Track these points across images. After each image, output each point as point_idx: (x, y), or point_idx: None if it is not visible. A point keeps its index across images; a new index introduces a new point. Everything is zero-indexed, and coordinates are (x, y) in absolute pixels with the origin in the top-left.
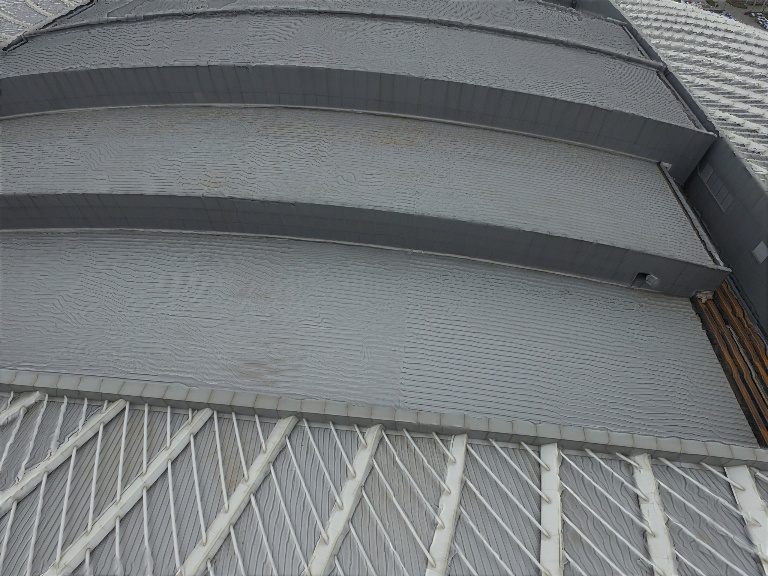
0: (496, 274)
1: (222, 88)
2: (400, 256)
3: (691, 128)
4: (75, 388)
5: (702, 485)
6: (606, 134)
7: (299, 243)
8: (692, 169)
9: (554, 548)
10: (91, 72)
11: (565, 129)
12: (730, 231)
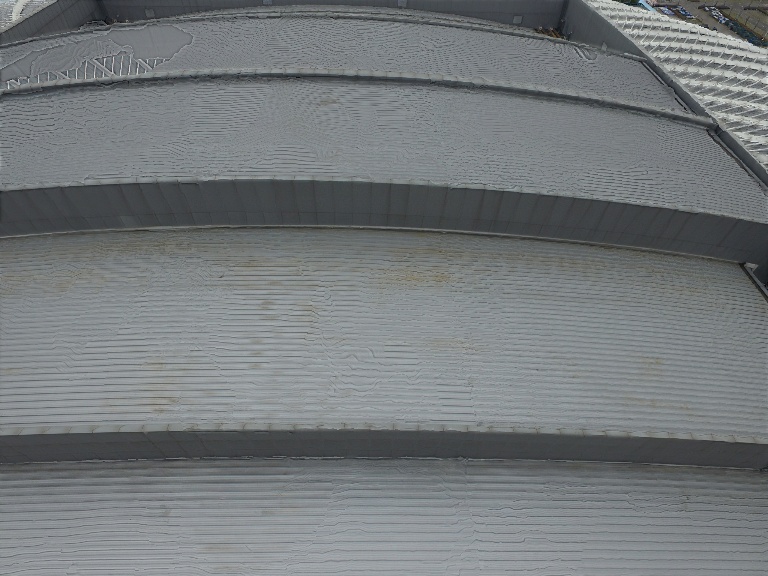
0: (587, 482)
1: (162, 209)
2: (448, 464)
3: None
4: None
5: None
6: (684, 238)
7: (300, 463)
8: None
9: None
10: None
11: (633, 235)
12: None
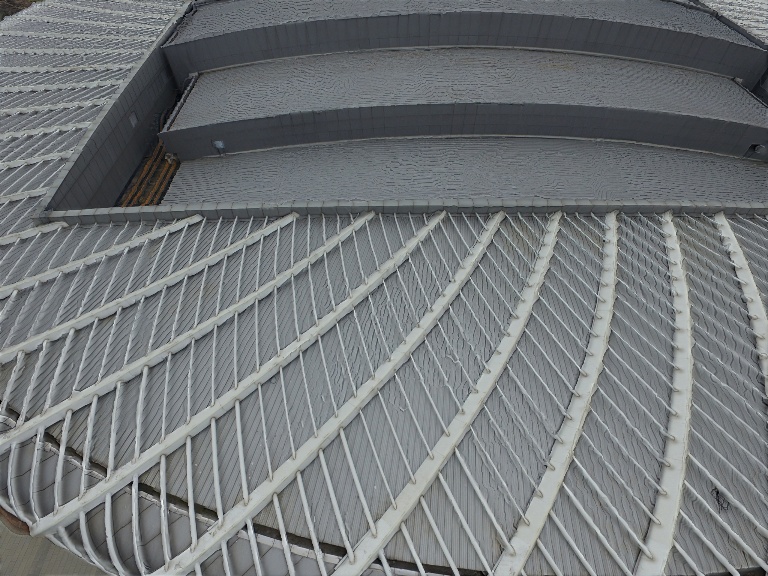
0: (656, 152)
1: (414, 33)
2: (585, 145)
3: (760, 49)
4: (472, 205)
5: None
6: (700, 57)
7: (514, 139)
8: (756, 82)
9: None
10: (308, 24)
11: (671, 54)
12: None
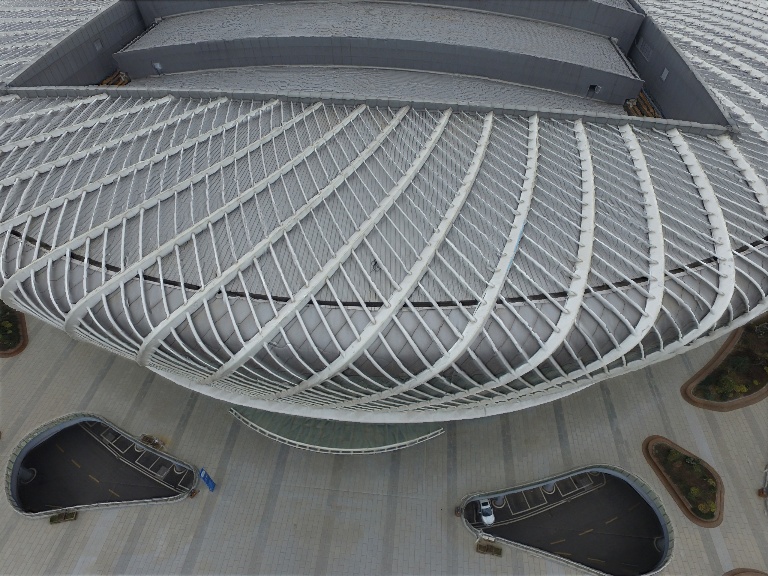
0: (505, 87)
1: None
2: (446, 79)
3: (628, 10)
4: (298, 96)
5: None
6: (574, 16)
7: (385, 71)
8: (632, 42)
9: (534, 142)
10: None
11: (548, 13)
12: (651, 71)
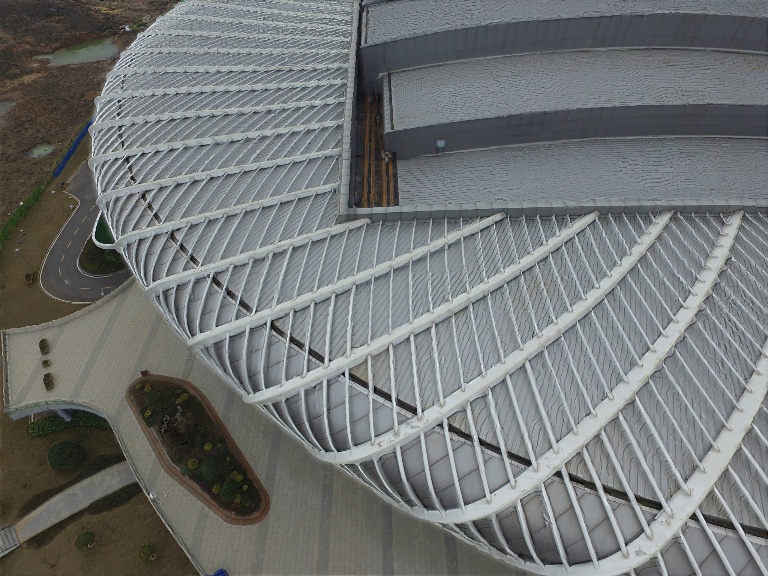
0: None
1: (612, 34)
2: None
3: None
4: None
5: None
6: None
7: (731, 140)
8: None
9: None
10: (511, 25)
11: None
12: None
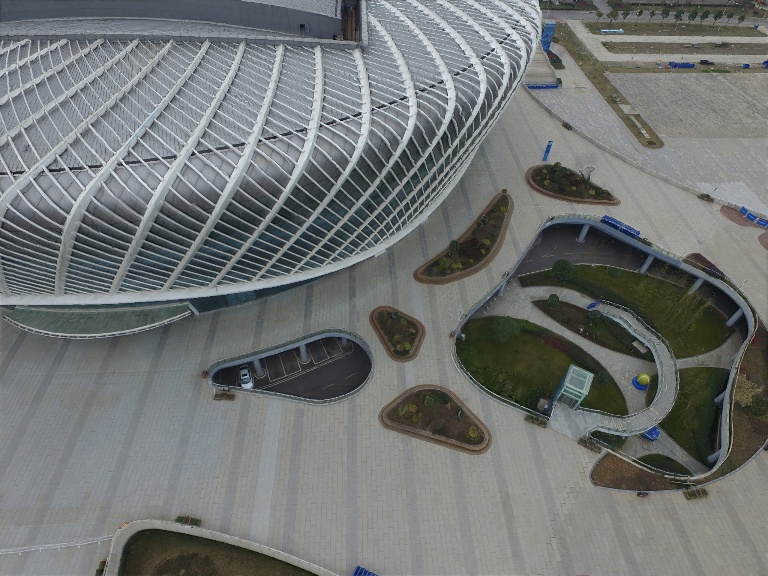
0: None
1: None
2: (180, 25)
3: None
4: (6, 34)
5: (262, 48)
6: None
7: (125, 21)
8: None
9: None
10: None
11: None
12: None
